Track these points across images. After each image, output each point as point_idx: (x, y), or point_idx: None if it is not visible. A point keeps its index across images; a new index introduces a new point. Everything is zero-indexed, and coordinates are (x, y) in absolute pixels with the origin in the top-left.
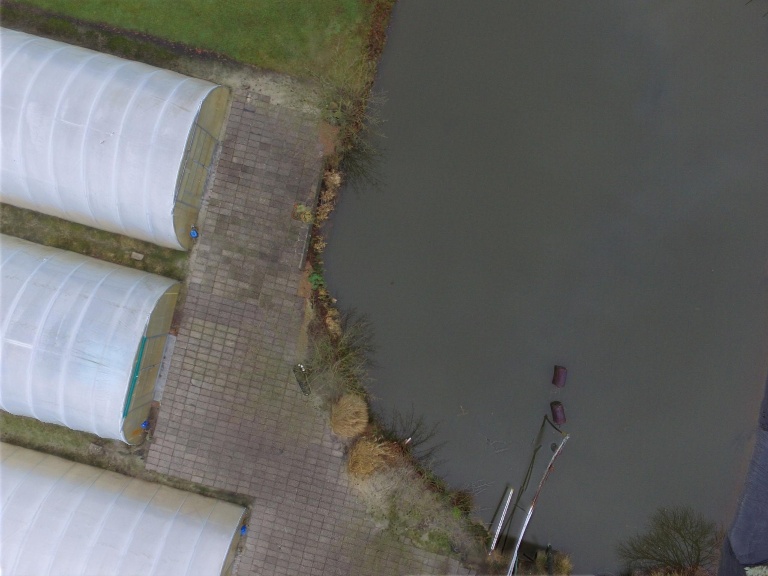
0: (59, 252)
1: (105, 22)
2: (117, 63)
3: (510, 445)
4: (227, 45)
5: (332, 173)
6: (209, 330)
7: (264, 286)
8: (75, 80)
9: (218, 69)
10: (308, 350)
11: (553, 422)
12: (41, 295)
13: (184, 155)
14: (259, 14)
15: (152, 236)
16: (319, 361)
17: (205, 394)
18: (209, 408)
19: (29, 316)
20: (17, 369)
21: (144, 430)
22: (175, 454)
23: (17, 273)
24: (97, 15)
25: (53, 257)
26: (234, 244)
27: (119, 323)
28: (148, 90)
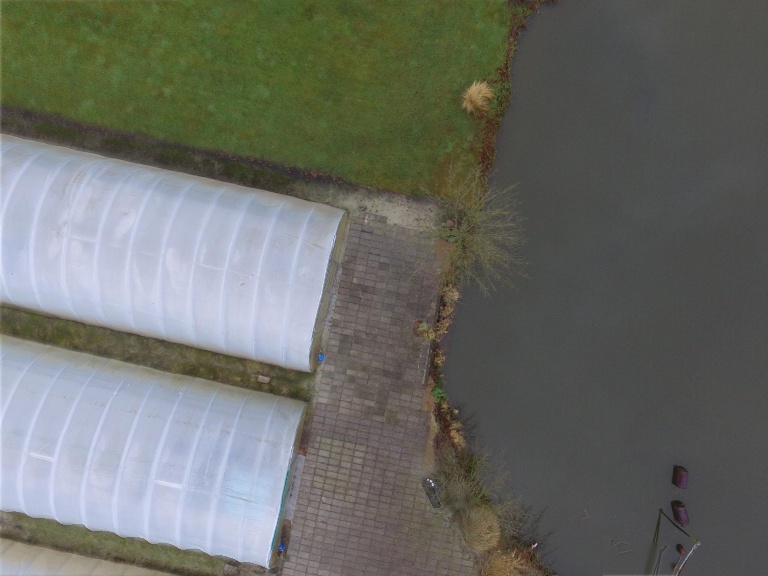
0: (189, 381)
1: (221, 150)
2: (243, 198)
3: (634, 546)
4: (342, 168)
5: (449, 288)
6: (337, 448)
7: (389, 403)
8: (210, 222)
9: (334, 192)
10: (435, 463)
11: (674, 520)
12: (185, 434)
13: (322, 294)
14: (372, 136)
15: (283, 364)
16: (446, 474)
17: (336, 511)
18: (340, 524)
19: (176, 457)
20: (167, 509)
21: (279, 550)
22: (309, 571)
23: (158, 411)
24: (213, 143)
25: (187, 389)
26: (358, 363)
27: (264, 459)
28: (280, 228)
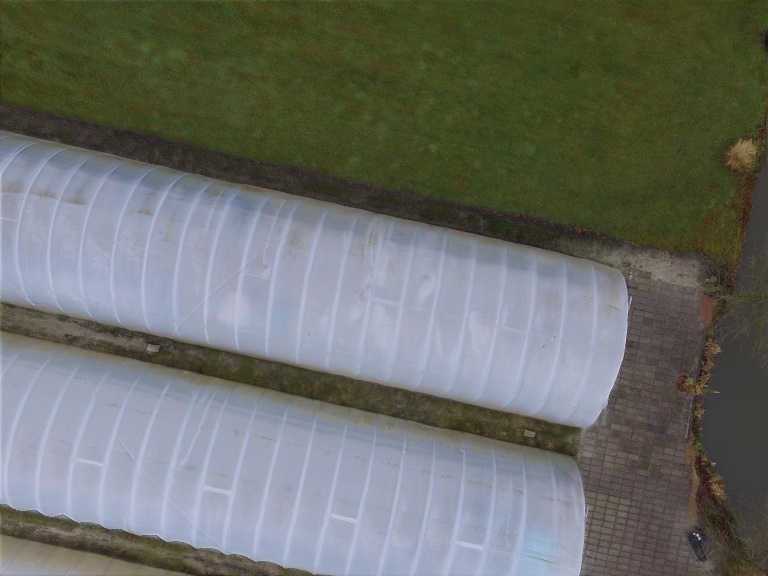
0: (461, 436)
1: (486, 206)
2: (527, 257)
3: None
4: (606, 224)
5: (710, 342)
6: (601, 502)
7: (653, 457)
8: (507, 284)
9: (598, 247)
10: (698, 517)
11: None
12: (480, 494)
13: None
14: (636, 192)
15: (560, 421)
16: (710, 528)
17: (600, 564)
18: None
19: (476, 517)
20: (466, 569)
21: None
22: None
23: (449, 470)
24: (478, 199)
25: (465, 446)
26: (622, 417)
27: (560, 518)
28: (573, 288)
